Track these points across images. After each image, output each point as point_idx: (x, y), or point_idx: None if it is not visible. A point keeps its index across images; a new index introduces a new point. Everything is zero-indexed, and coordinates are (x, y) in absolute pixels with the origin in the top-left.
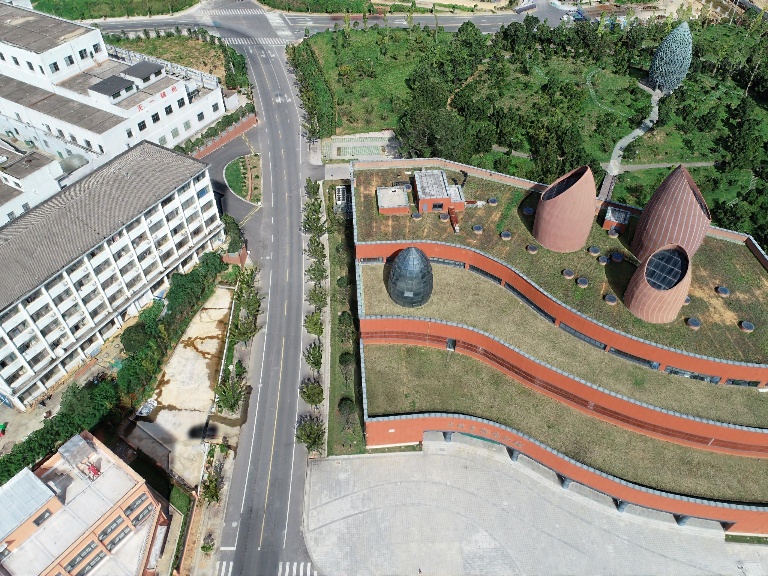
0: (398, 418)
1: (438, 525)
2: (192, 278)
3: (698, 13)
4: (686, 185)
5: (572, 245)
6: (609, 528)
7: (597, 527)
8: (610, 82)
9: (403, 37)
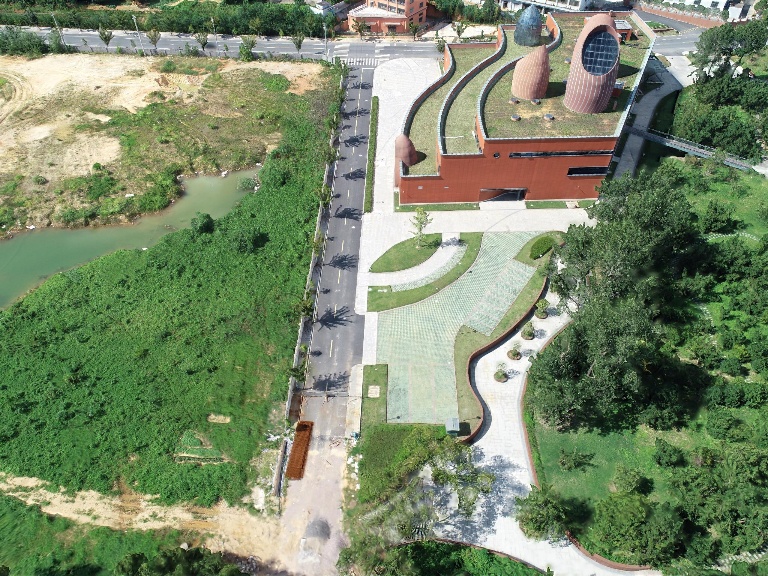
0: None
1: None
2: None
3: None
4: None
5: None
6: None
7: None
8: None
9: None
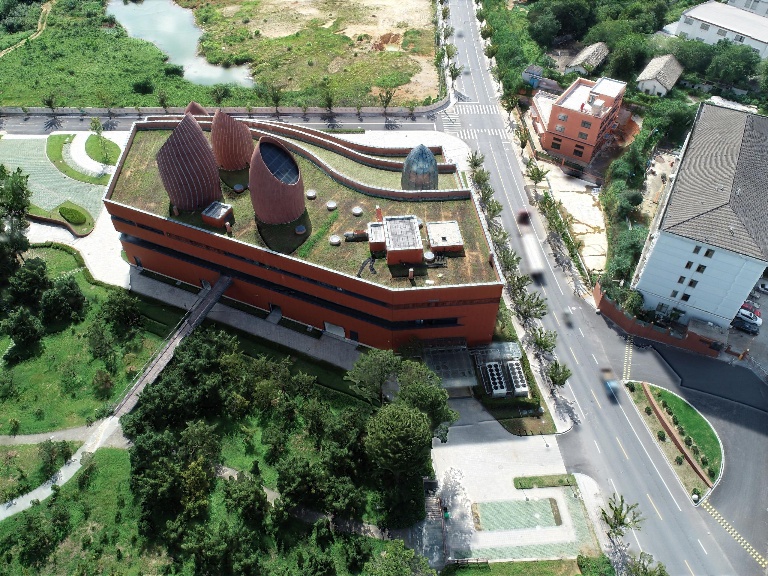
0: None
1: None
2: (625, 247)
3: None
4: None
5: None
6: None
7: None
8: None
9: None
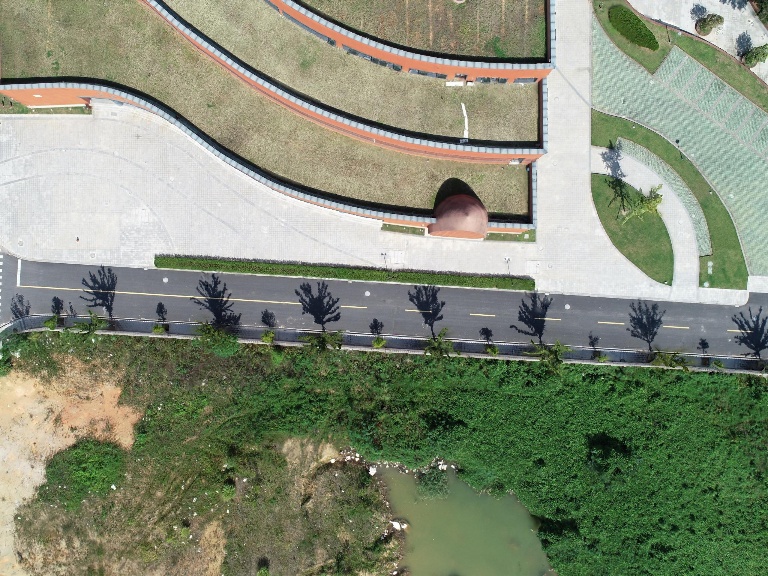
0: (29, 87)
1: (100, 197)
2: None
3: None
4: None
5: None
6: (270, 210)
7: (259, 209)
8: None
9: None
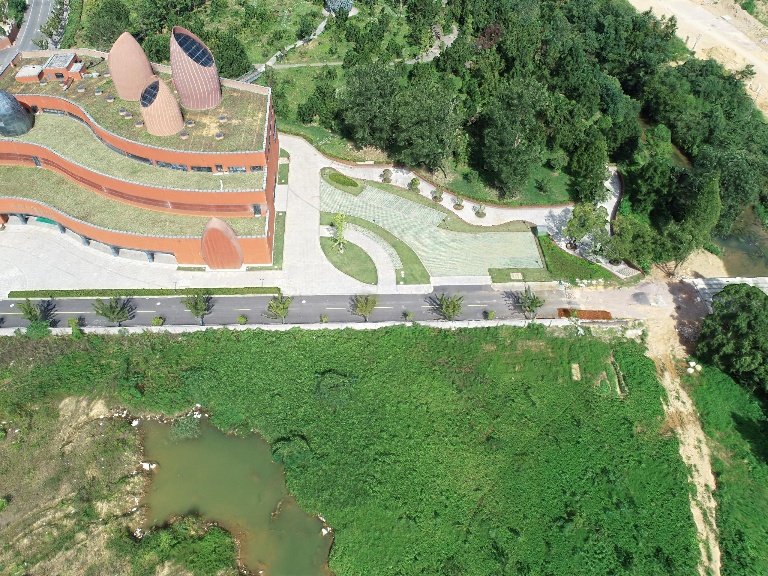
0: None
1: None
2: None
3: None
4: (173, 38)
5: (134, 94)
6: (103, 265)
7: (95, 265)
8: (304, 10)
9: None
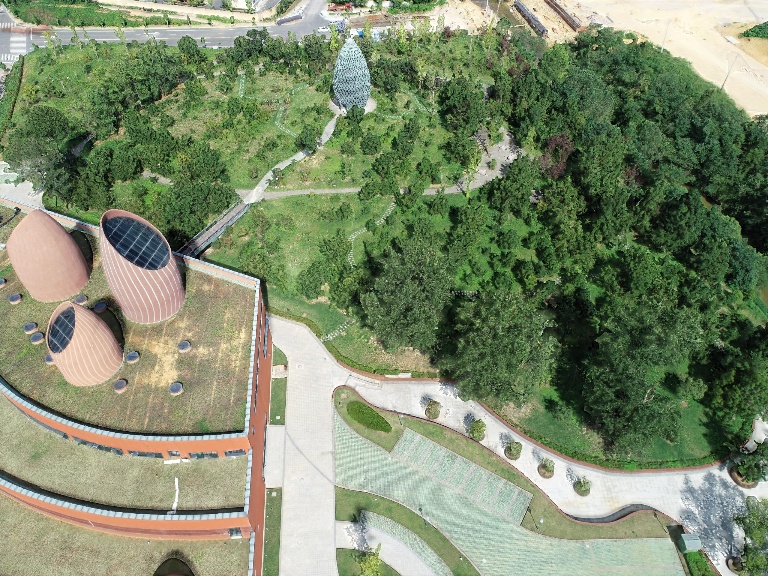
0: None
1: None
2: None
3: (468, 23)
4: (102, 234)
5: (51, 295)
6: None
7: None
8: (305, 100)
9: (119, 53)
